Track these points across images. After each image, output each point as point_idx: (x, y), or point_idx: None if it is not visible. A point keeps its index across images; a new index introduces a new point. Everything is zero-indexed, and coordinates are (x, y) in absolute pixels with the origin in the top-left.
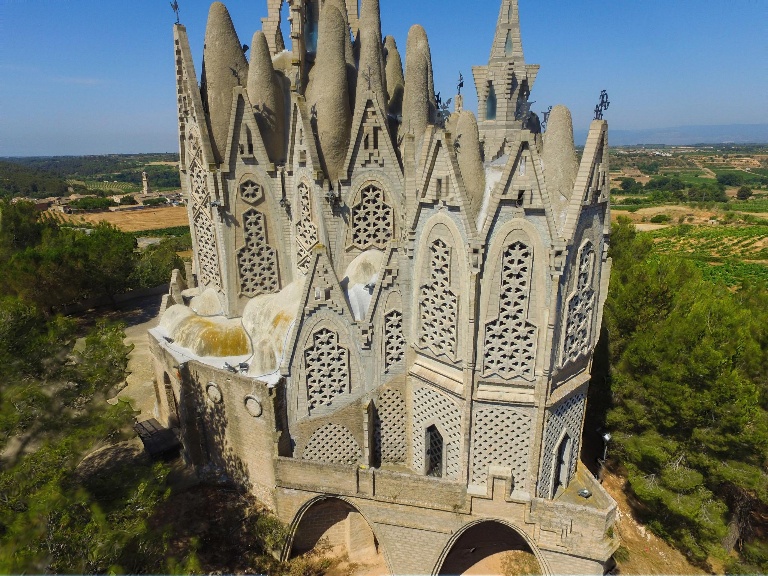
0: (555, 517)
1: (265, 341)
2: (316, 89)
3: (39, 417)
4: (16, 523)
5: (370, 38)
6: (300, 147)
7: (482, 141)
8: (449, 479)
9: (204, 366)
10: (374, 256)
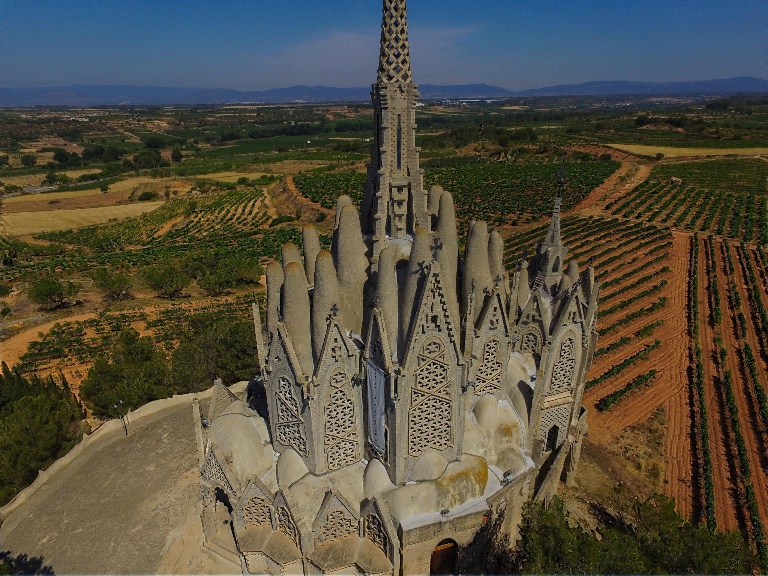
0: (581, 425)
1: (511, 448)
2: (483, 276)
3: None
4: (710, 539)
5: (499, 238)
6: (493, 318)
7: (556, 284)
8: (565, 443)
9: (498, 495)
10: (517, 361)
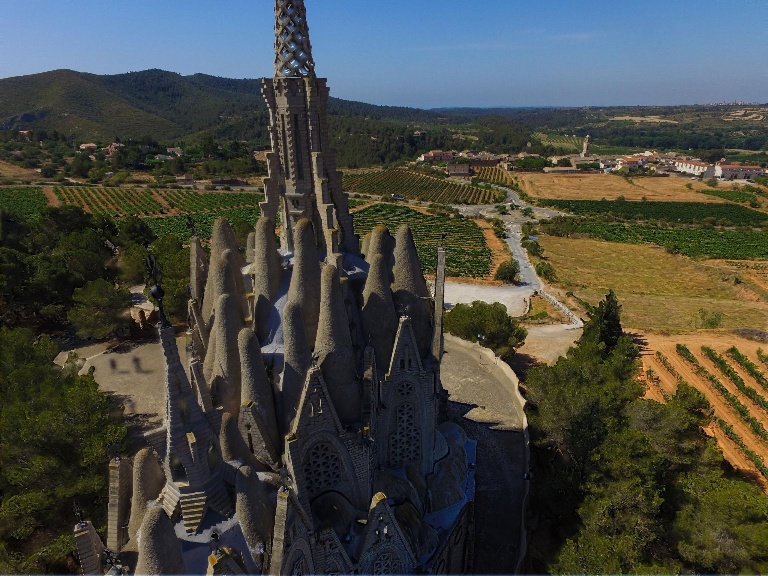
0: None
1: None
2: None
3: (53, 470)
4: None
5: (218, 305)
6: None
7: None
8: None
9: None
10: None
